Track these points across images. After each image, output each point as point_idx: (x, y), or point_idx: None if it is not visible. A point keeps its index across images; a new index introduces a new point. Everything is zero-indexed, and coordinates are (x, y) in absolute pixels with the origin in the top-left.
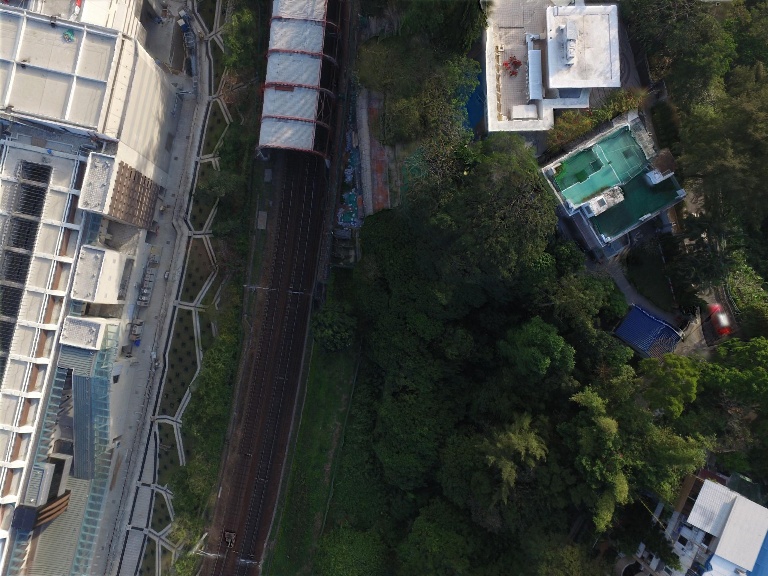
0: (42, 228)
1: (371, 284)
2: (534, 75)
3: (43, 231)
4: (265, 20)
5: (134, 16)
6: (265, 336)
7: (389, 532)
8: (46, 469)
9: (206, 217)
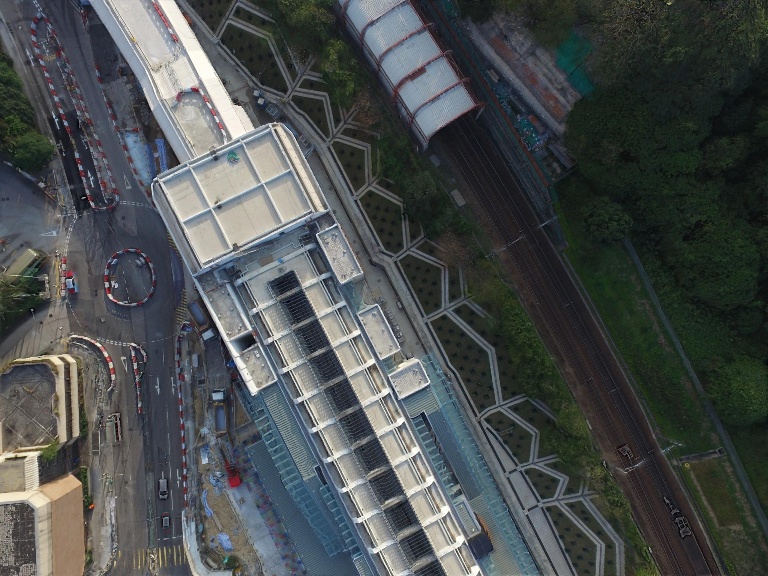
0: (323, 322)
1: (610, 167)
2: None
3: (325, 324)
4: None
5: None
6: (531, 283)
7: (749, 349)
8: (464, 500)
9: (401, 235)
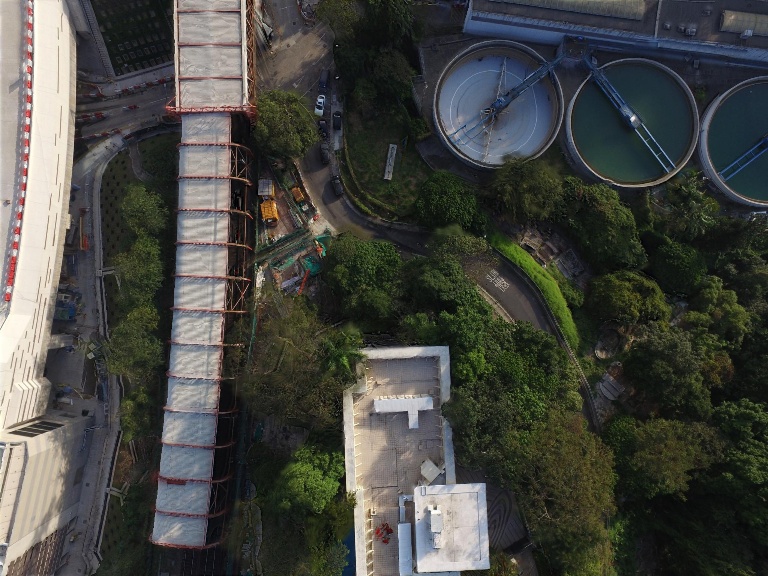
0: None
1: None
2: (404, 551)
3: None
4: (166, 382)
5: (33, 389)
6: None
7: None
8: None
9: None
